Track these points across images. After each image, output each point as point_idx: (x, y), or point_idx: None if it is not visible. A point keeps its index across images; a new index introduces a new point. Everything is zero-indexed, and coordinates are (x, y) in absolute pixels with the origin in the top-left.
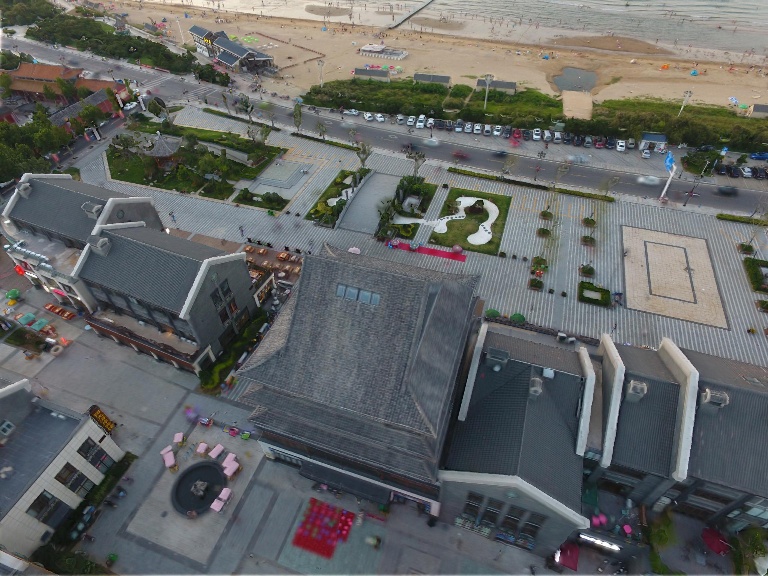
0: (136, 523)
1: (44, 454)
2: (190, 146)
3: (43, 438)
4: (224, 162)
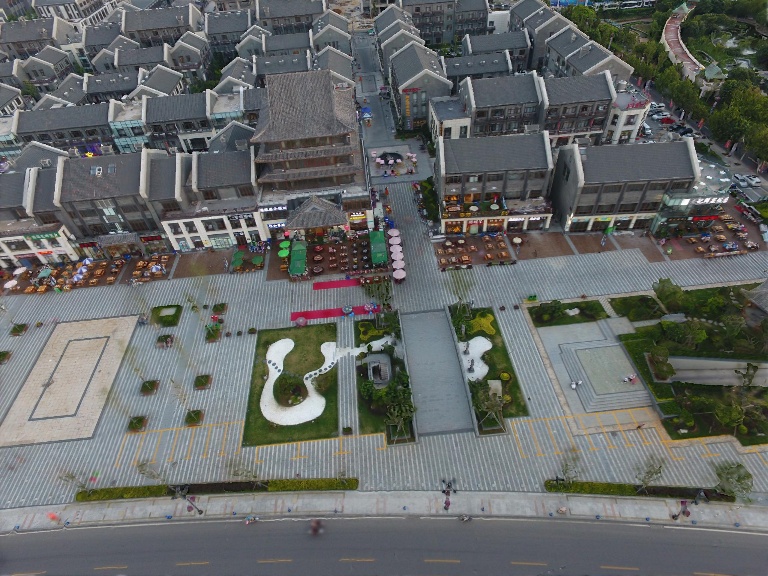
0: (406, 147)
1: (444, 115)
2: (763, 324)
3: (452, 117)
4: (677, 324)
